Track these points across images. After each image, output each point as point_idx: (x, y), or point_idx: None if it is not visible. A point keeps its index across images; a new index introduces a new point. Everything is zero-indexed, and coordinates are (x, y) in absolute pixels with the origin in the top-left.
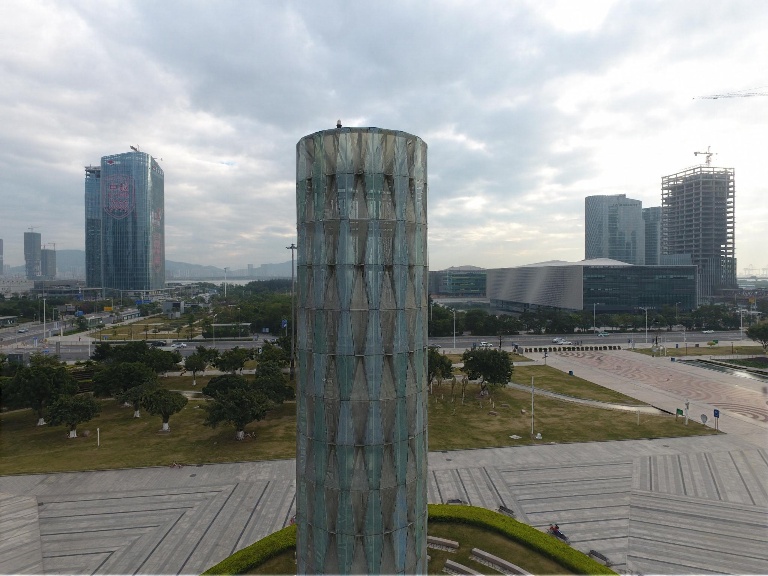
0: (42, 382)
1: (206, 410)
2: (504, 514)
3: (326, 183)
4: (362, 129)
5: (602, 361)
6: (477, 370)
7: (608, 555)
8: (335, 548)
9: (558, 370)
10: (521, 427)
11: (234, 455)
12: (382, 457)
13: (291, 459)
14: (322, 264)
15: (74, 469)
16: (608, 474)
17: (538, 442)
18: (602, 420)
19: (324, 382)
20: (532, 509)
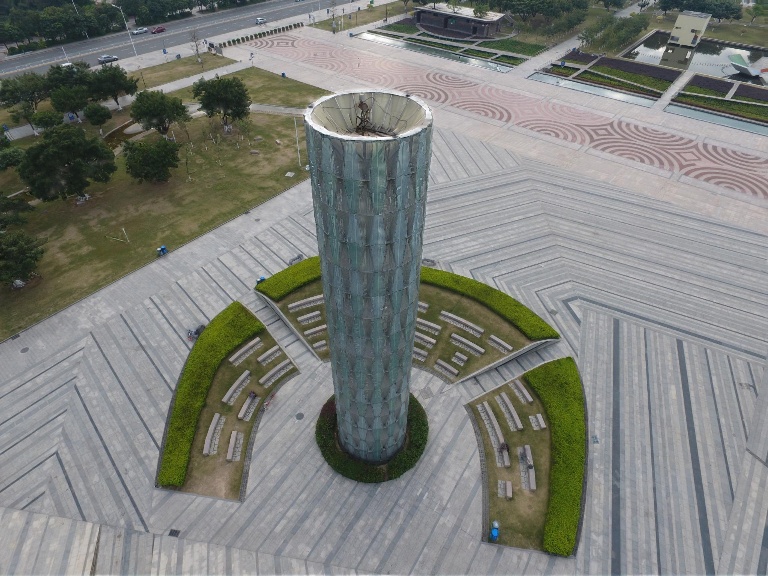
0: None
1: None
2: None
3: (386, 186)
4: (416, 134)
5: (298, 49)
6: (216, 106)
7: None
8: (387, 376)
9: (269, 72)
10: (287, 161)
11: (42, 307)
12: None
13: (114, 282)
14: (381, 244)
15: None
16: None
17: None
18: None
19: (382, 310)
20: None
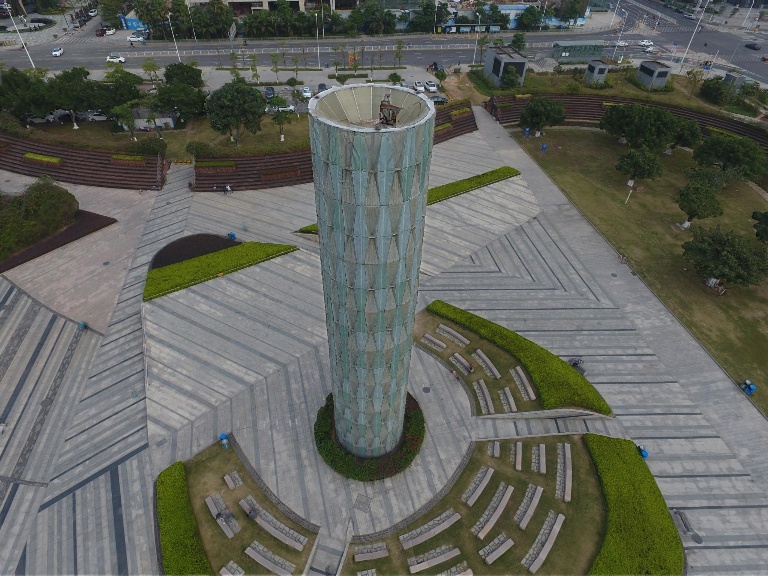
0: (645, 126)
1: (693, 234)
2: None
3: None
4: None
5: None
6: None
7: None
8: None
9: None
10: None
11: (668, 290)
12: None
13: (694, 338)
14: None
15: (583, 210)
16: None
17: None
18: None
19: None
20: None
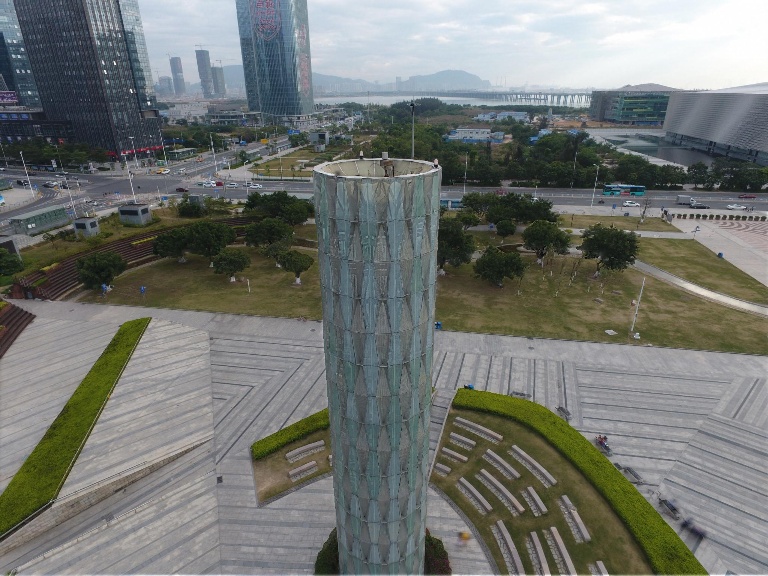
0: (207, 236)
1: None
2: (561, 414)
3: (329, 224)
4: (356, 180)
5: None
6: (595, 250)
7: (645, 474)
8: (348, 476)
9: (706, 249)
10: (623, 321)
11: None
12: (379, 432)
13: None
14: (330, 290)
15: (233, 312)
16: (693, 391)
17: (633, 342)
18: (725, 325)
19: (336, 375)
20: (591, 414)
